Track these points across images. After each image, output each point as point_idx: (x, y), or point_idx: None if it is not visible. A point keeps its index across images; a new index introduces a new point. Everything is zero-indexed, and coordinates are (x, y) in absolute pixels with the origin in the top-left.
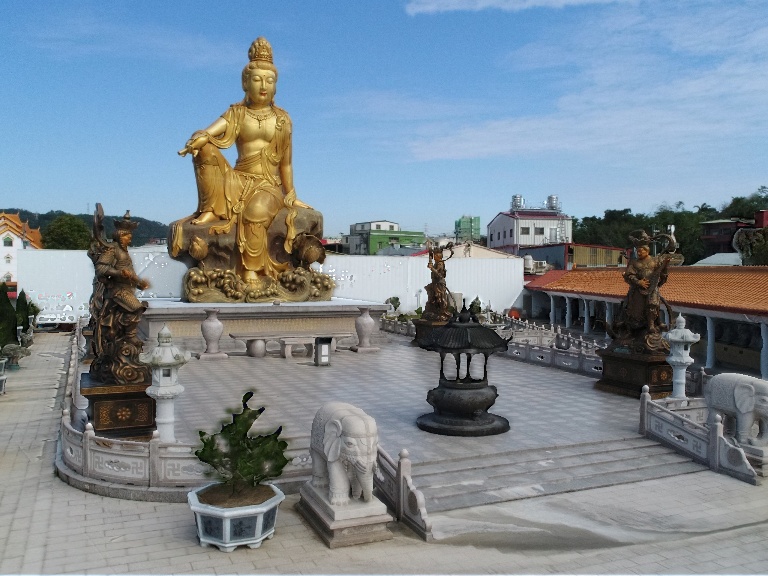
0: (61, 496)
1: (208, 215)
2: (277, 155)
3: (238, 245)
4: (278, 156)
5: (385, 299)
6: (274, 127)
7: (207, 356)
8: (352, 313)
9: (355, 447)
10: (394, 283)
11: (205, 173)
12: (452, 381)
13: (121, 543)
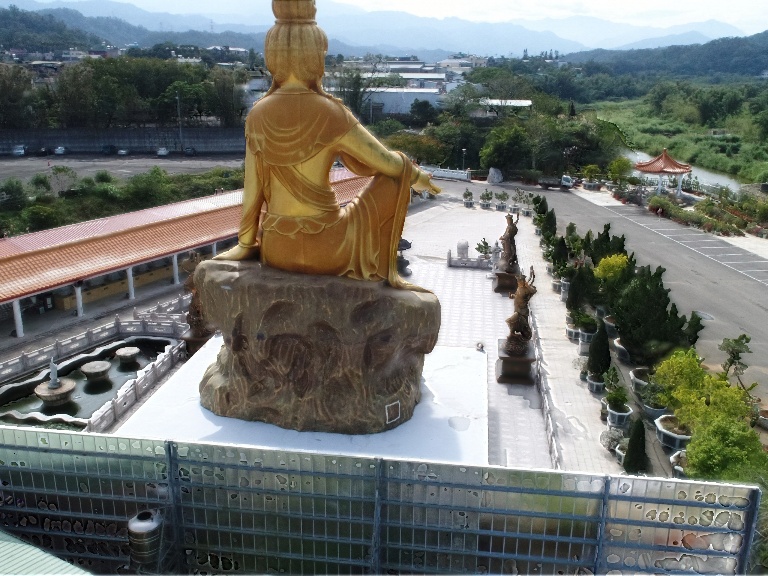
0: None
1: None
2: None
3: None
4: None
5: None
6: None
7: None
8: None
9: None
10: None
11: None
12: None
13: None
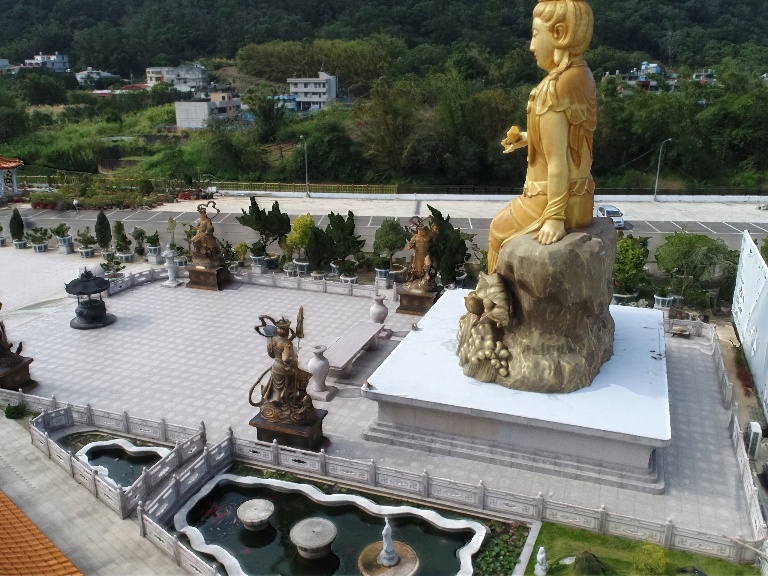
0: None
1: None
2: None
3: None
4: None
5: None
6: None
7: None
8: None
9: None
10: None
11: None
12: (99, 304)
13: None
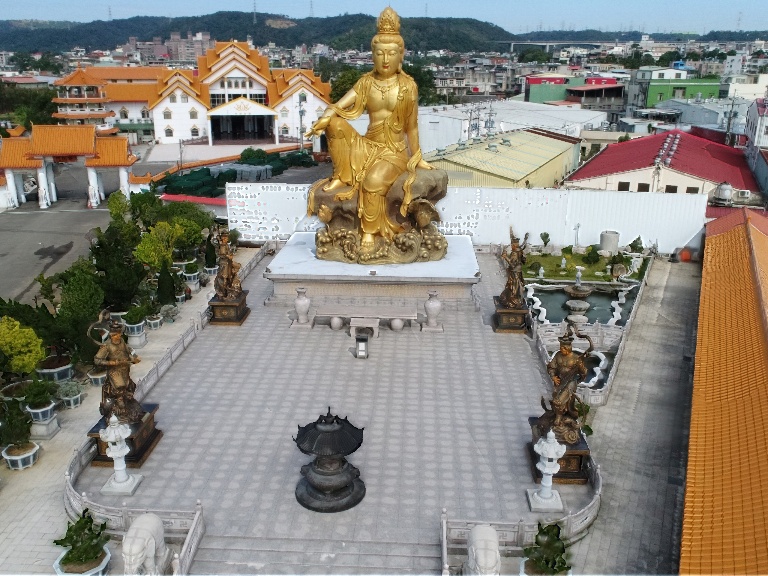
0: (52, 510)
1: (336, 182)
2: (399, 124)
3: (358, 211)
4: (400, 125)
5: (541, 231)
6: (396, 98)
7: (296, 326)
8: (442, 283)
9: (125, 559)
10: (552, 216)
11: (333, 146)
12: None
13: (36, 566)
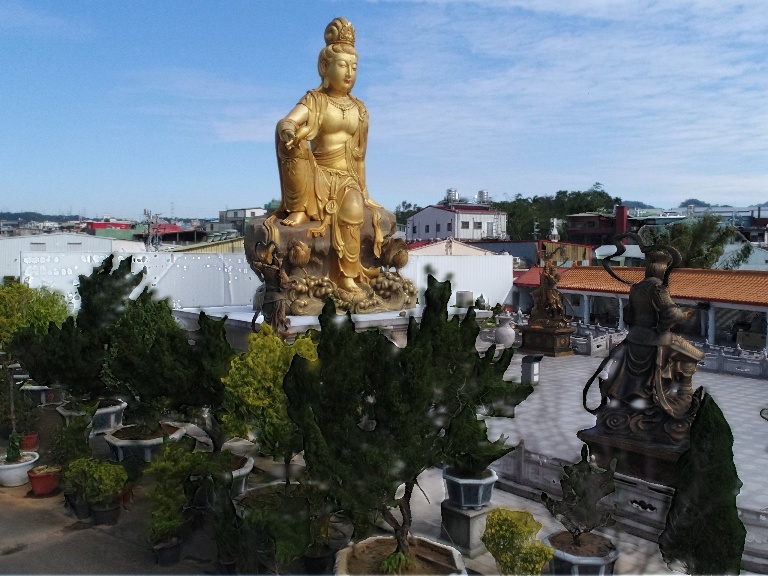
0: None
1: (301, 215)
2: (360, 149)
3: (336, 249)
4: (360, 150)
5: None
6: (357, 118)
7: None
8: None
9: None
10: None
11: (298, 168)
12: None
13: None
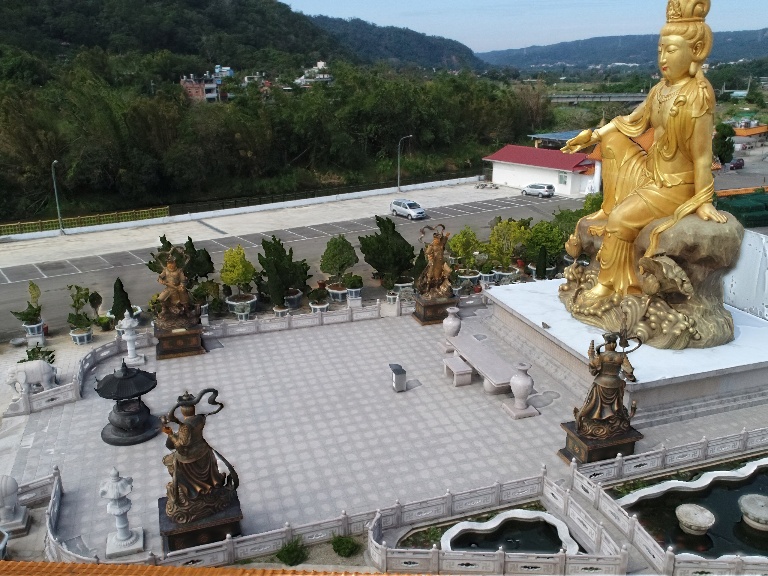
0: None
1: (600, 212)
2: (669, 148)
3: None
4: (670, 149)
5: None
6: (669, 111)
7: None
8: None
9: None
10: None
11: None
12: (142, 404)
13: None
